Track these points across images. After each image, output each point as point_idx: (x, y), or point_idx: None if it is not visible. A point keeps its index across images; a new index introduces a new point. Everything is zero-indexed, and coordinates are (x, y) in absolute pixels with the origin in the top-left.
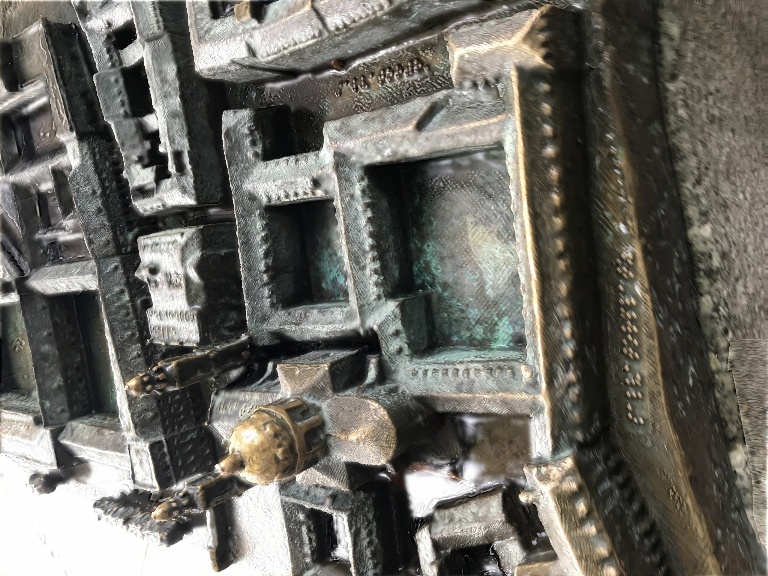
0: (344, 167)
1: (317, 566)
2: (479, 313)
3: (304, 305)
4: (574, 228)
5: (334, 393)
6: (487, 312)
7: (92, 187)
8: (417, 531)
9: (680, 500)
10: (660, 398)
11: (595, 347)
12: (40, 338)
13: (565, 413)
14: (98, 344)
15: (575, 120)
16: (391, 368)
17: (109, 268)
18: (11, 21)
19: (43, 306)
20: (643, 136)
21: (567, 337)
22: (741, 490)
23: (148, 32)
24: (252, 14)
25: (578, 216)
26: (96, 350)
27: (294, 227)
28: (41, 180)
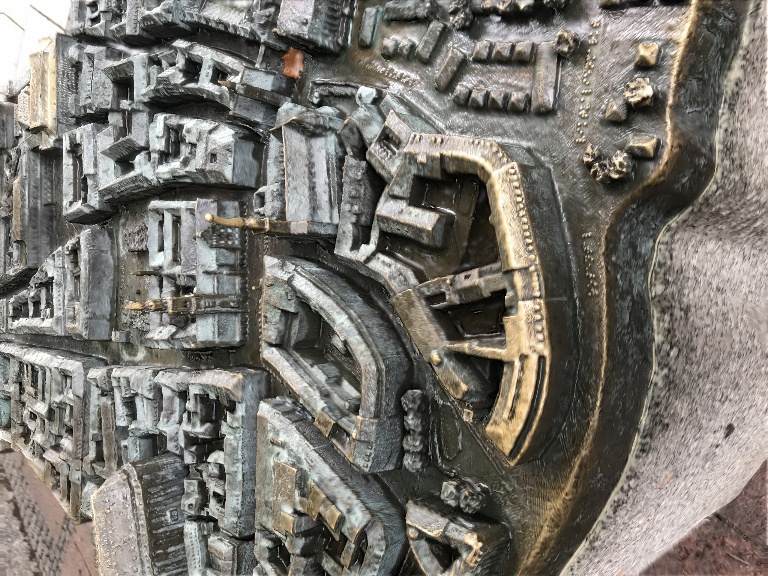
0: None
1: None
2: None
3: (8, 361)
4: None
5: None
6: None
7: None
8: None
9: None
10: None
11: None
12: None
13: None
14: None
15: None
16: None
17: None
18: None
19: None
20: None
21: None
22: None
23: (22, 329)
24: None
25: None
26: None
27: None
28: None
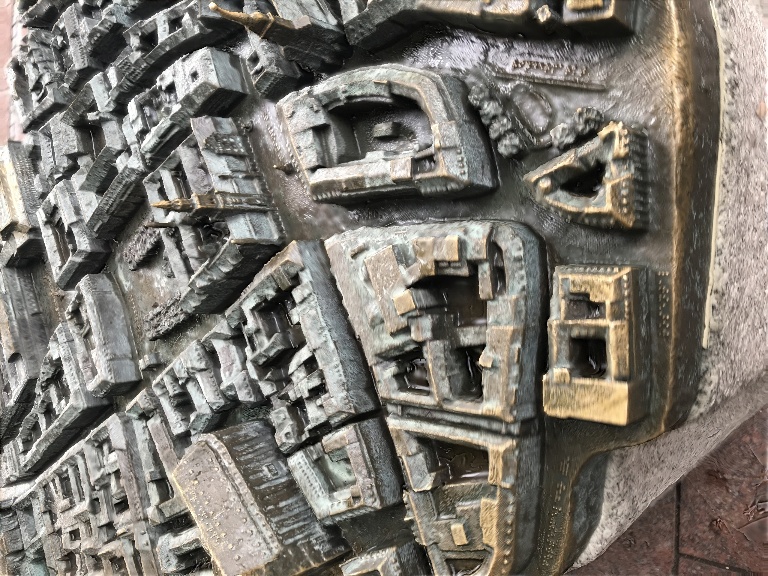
0: None
1: None
2: None
3: (29, 515)
4: None
5: (5, 557)
6: None
7: (11, 413)
8: None
9: None
10: None
11: None
12: None
13: None
14: None
15: None
16: (24, 561)
17: (1, 428)
18: (48, 287)
19: None
20: None
21: None
22: None
23: (38, 450)
24: None
25: None
26: None
27: None
28: None
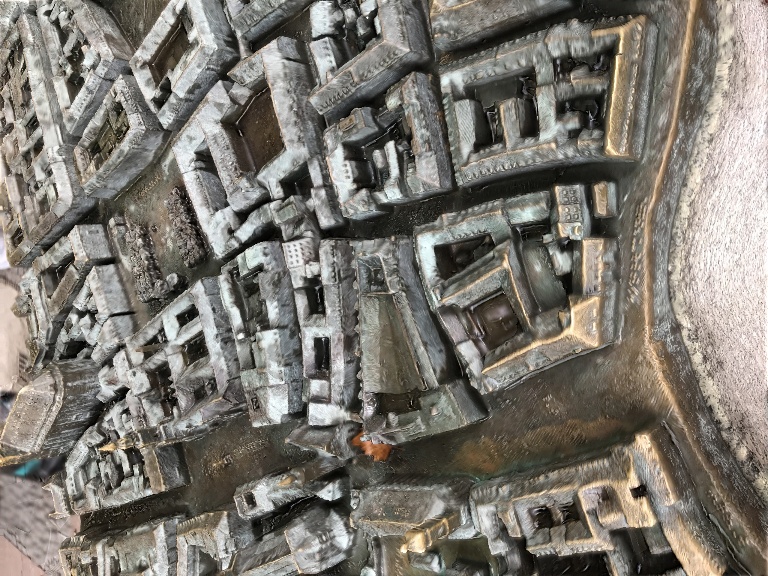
0: None
1: None
2: None
3: None
4: None
5: None
6: None
7: None
8: None
9: None
10: None
11: None
12: None
13: None
14: None
15: None
16: None
17: None
18: None
19: None
20: None
21: None
22: None
23: None
24: None
25: None
26: None
27: None
28: None
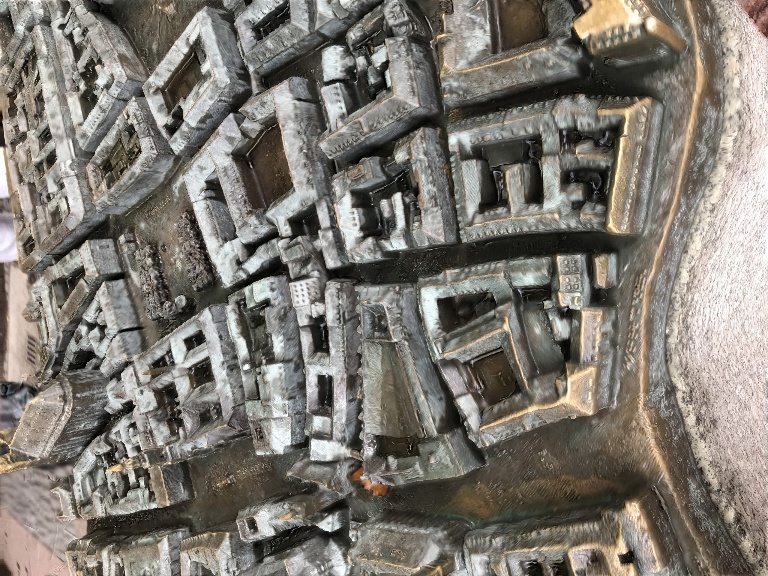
0: None
1: None
2: None
3: None
4: None
5: None
6: None
7: None
8: None
9: None
10: None
11: None
12: None
13: None
14: None
15: None
16: None
17: None
18: None
19: None
20: None
21: None
22: None
23: None
24: None
25: None
26: None
27: None
28: None
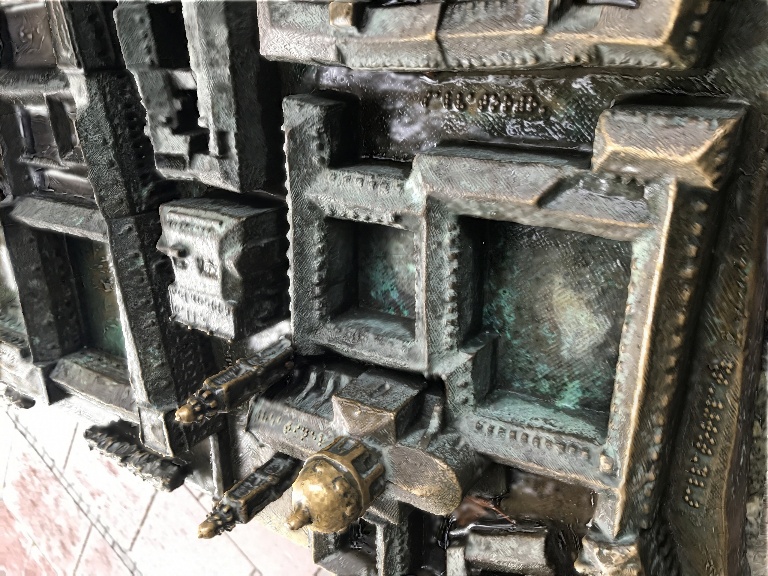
0: (436, 213)
1: (339, 552)
2: (548, 369)
3: (354, 319)
4: (687, 341)
5: (397, 440)
6: (557, 371)
7: (103, 136)
8: (449, 546)
9: (714, 572)
10: (721, 490)
11: (672, 440)
12: (27, 272)
13: (636, 505)
14: (91, 279)
15: (714, 230)
16: (453, 416)
17: (122, 229)
18: None
19: (30, 238)
20: (766, 236)
21: (656, 442)
22: (748, 534)
23: None
24: (353, 22)
25: (692, 326)
26: (89, 286)
27: (349, 233)
28: (28, 99)
